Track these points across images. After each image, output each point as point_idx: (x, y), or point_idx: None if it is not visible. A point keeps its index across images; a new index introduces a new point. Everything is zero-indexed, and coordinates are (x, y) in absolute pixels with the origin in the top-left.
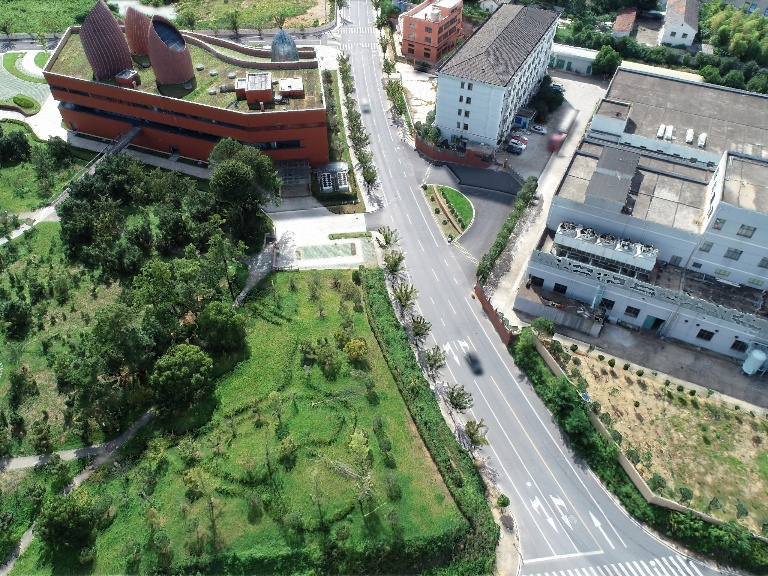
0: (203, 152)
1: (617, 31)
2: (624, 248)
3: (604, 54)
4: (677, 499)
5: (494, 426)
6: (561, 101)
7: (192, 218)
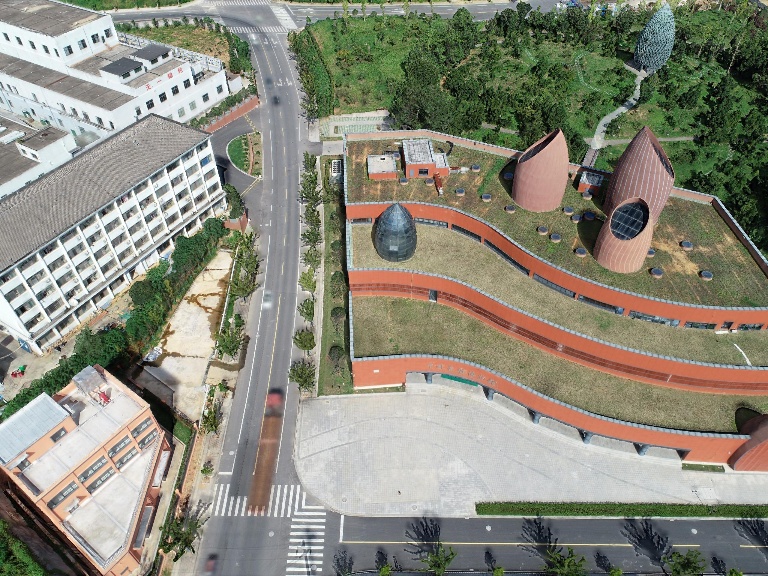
0: None
1: None
2: None
3: None
4: (219, 34)
5: (281, 59)
6: None
7: None
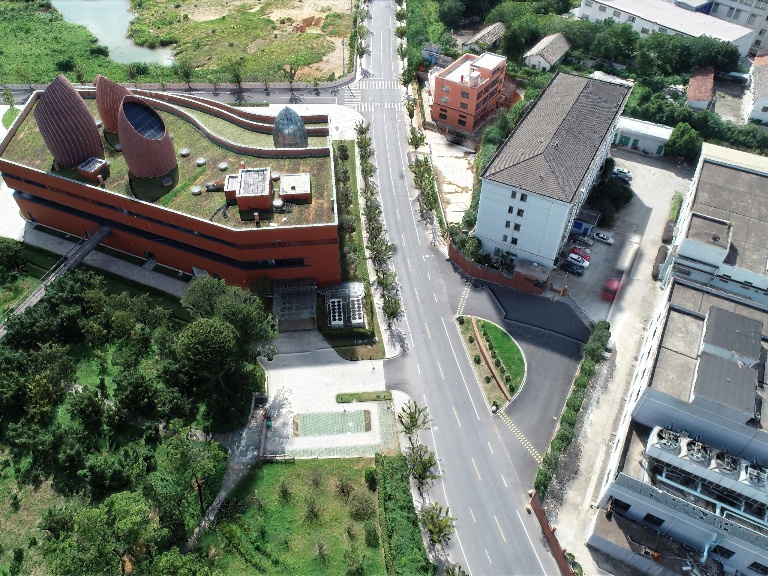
0: (184, 262)
1: (693, 100)
2: (752, 481)
3: (681, 134)
4: None
5: None
6: (630, 197)
7: (158, 378)
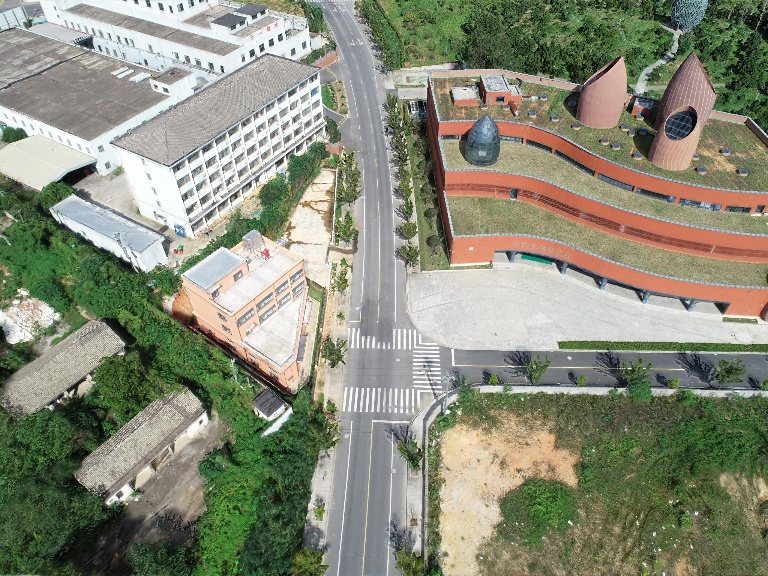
0: None
1: None
2: None
3: None
4: None
5: (350, 24)
6: None
7: None
